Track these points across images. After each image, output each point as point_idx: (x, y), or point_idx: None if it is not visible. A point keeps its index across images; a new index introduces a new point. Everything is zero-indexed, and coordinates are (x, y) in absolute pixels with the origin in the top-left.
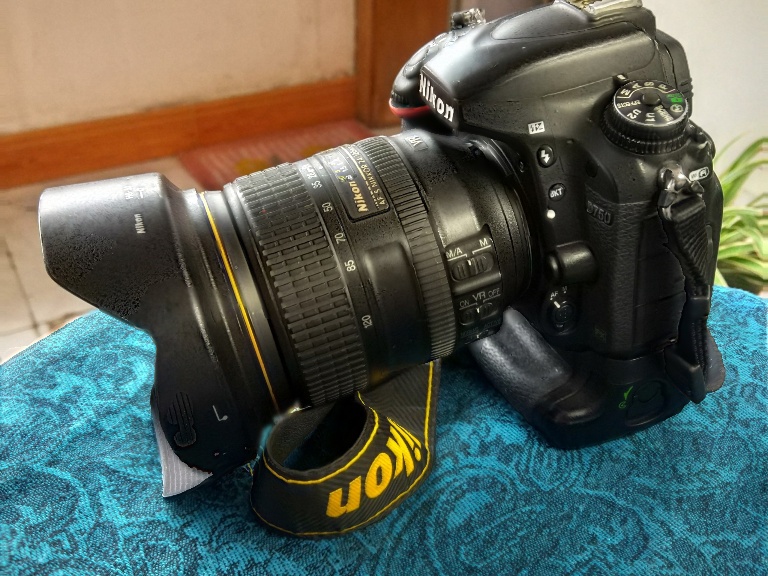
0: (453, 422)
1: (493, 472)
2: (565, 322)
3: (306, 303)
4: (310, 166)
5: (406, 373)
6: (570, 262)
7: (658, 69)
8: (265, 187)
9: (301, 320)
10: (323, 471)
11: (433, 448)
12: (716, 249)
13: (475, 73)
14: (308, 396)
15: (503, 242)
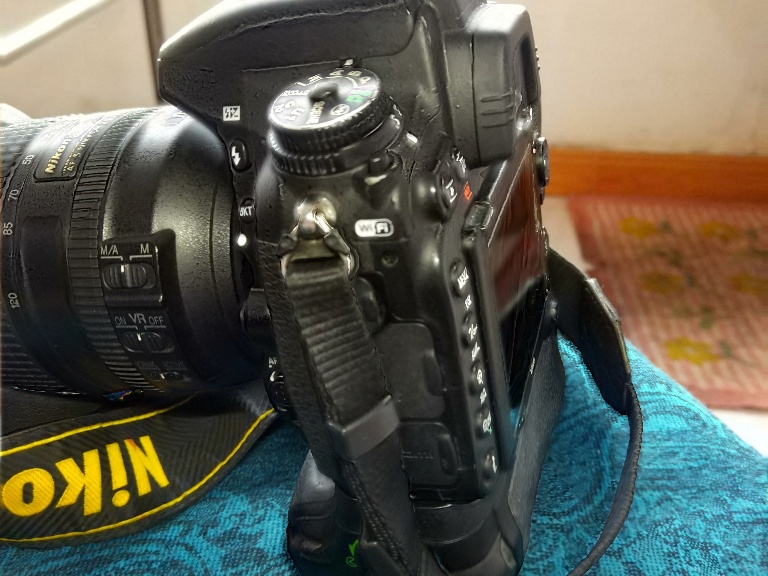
0: (239, 492)
1: (200, 567)
2: (289, 406)
3: None
4: None
5: (232, 414)
6: (256, 315)
7: (418, 62)
8: (18, 129)
9: None
10: None
11: (182, 507)
12: (455, 372)
13: (190, 28)
14: None
15: (196, 262)
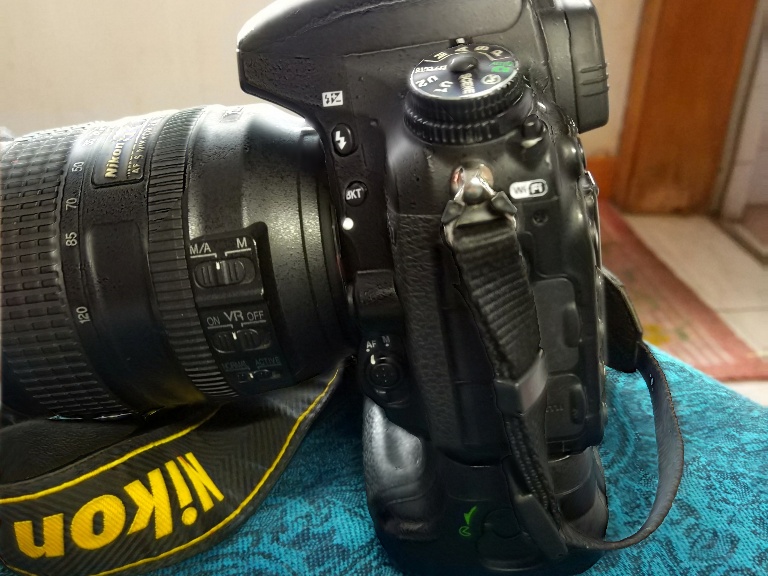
0: (294, 496)
1: (286, 571)
2: (389, 388)
3: (10, 273)
4: (108, 125)
5: (267, 421)
6: (369, 297)
7: (527, 38)
8: (44, 139)
9: (2, 293)
10: (0, 490)
11: (243, 519)
12: (591, 322)
13: (271, 19)
14: (33, 397)
15: (289, 253)
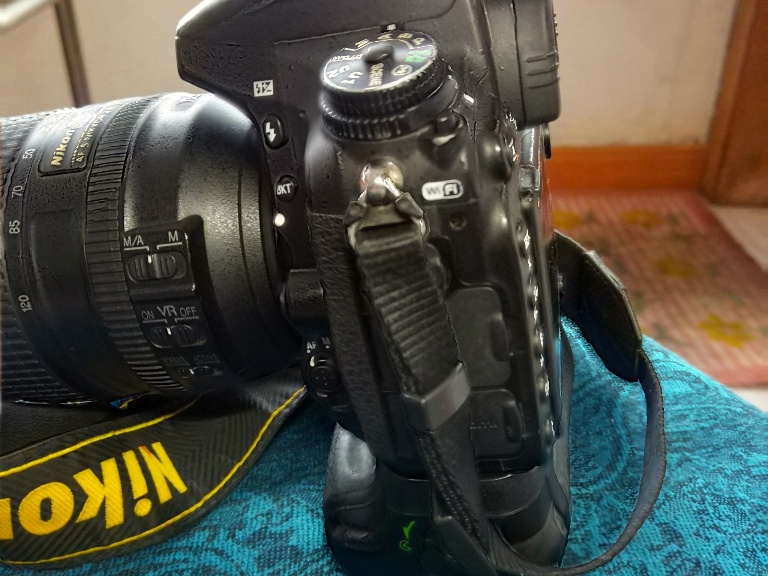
0: (260, 492)
1: (234, 570)
2: (330, 391)
3: None
4: None
5: (242, 414)
6: (299, 297)
7: (463, 24)
8: (8, 124)
9: None
10: None
11: (203, 512)
12: (522, 335)
13: (209, 4)
14: None
15: (226, 247)
